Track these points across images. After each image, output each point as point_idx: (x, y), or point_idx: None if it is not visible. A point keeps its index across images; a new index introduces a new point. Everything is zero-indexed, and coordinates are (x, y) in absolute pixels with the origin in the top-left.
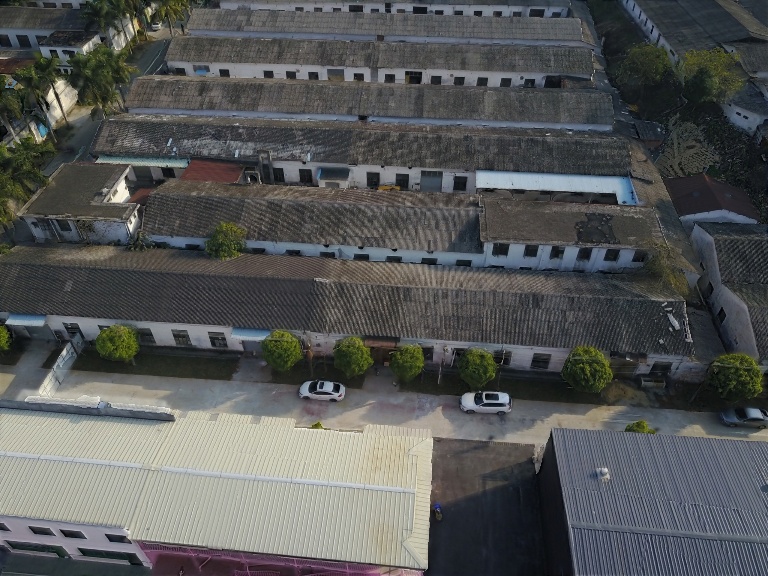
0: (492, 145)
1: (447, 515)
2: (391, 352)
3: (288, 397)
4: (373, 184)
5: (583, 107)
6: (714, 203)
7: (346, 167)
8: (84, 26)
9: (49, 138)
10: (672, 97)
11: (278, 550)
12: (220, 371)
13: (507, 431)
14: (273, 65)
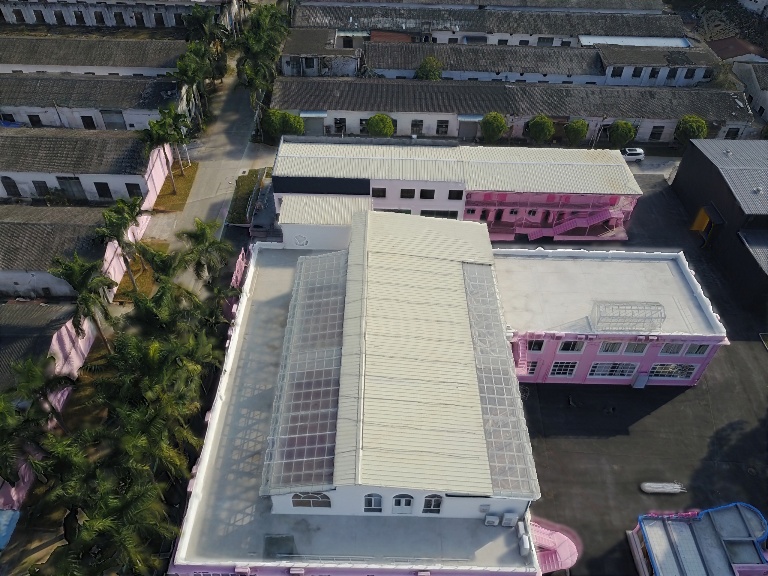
0: (587, 19)
1: None
2: (566, 125)
3: None
4: None
5: None
6: (745, 50)
7: (484, 36)
8: None
9: (234, 27)
10: None
11: (556, 191)
12: None
13: (644, 169)
14: None
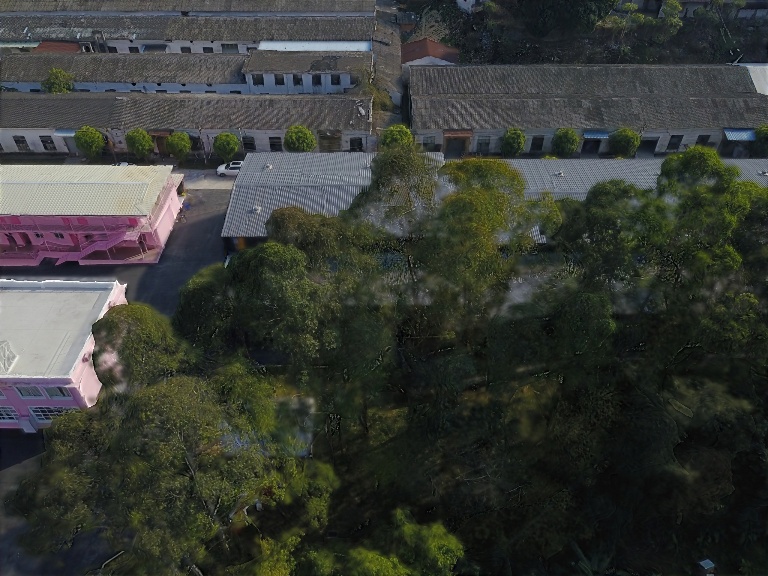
0: (275, 24)
1: (190, 221)
2: (166, 138)
3: None
4: None
5: (353, 0)
6: (425, 53)
7: (164, 43)
8: None
9: None
10: None
11: (56, 213)
12: (50, 164)
13: None
14: None
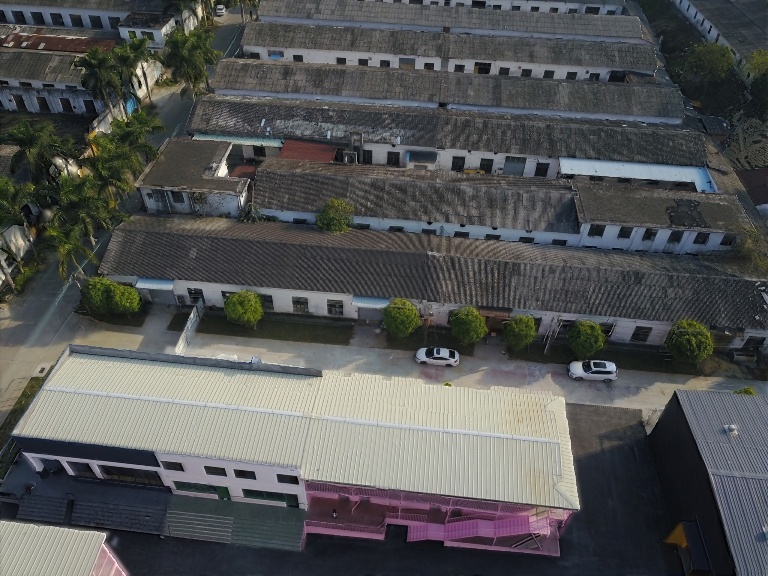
0: (573, 134)
1: None
2: (505, 321)
3: (405, 362)
4: (457, 168)
5: (654, 101)
6: None
7: (434, 151)
8: (157, 9)
9: None
10: (735, 94)
11: (441, 491)
12: (337, 337)
13: (614, 397)
14: (347, 52)
